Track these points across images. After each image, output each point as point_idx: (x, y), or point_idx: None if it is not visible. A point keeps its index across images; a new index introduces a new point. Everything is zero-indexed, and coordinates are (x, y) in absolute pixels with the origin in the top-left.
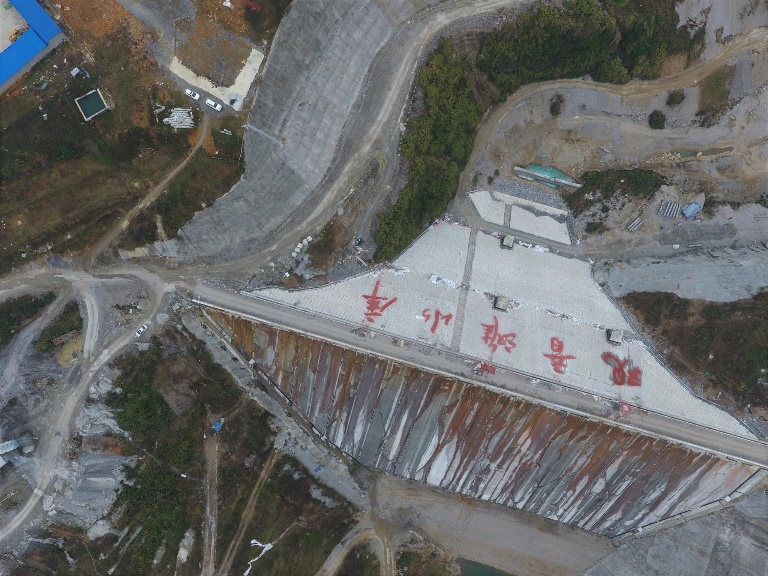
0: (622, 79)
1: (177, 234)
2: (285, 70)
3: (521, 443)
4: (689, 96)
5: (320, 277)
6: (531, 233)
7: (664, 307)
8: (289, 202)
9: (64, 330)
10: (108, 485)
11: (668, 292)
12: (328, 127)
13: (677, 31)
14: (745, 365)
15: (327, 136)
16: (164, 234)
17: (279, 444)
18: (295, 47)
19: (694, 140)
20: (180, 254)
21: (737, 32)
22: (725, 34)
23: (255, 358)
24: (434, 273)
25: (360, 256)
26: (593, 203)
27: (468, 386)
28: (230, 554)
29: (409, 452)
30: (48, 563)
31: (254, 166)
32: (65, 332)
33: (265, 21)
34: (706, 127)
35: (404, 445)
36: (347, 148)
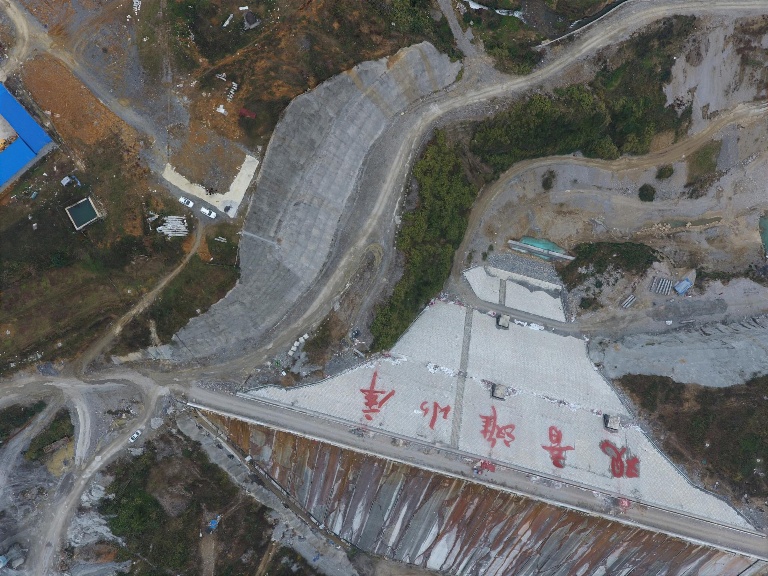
0: (612, 156)
1: (171, 340)
2: (280, 173)
3: (521, 534)
4: (678, 170)
5: (317, 373)
6: (526, 311)
7: (660, 391)
8: (285, 300)
9: (55, 438)
10: None
11: (663, 376)
12: (323, 223)
13: (665, 110)
14: (741, 455)
15: (322, 231)
16: (158, 339)
17: (277, 537)
18: (290, 150)
19: (683, 211)
20: (174, 357)
21: (722, 108)
22: (711, 110)
23: (252, 455)
24: (431, 361)
25: (357, 348)
26: (586, 277)
27: (468, 483)
28: None
29: (409, 540)
30: None
31: (249, 270)
32: (56, 440)
33: (259, 128)
34: (694, 198)
35: (404, 534)
36: (343, 242)
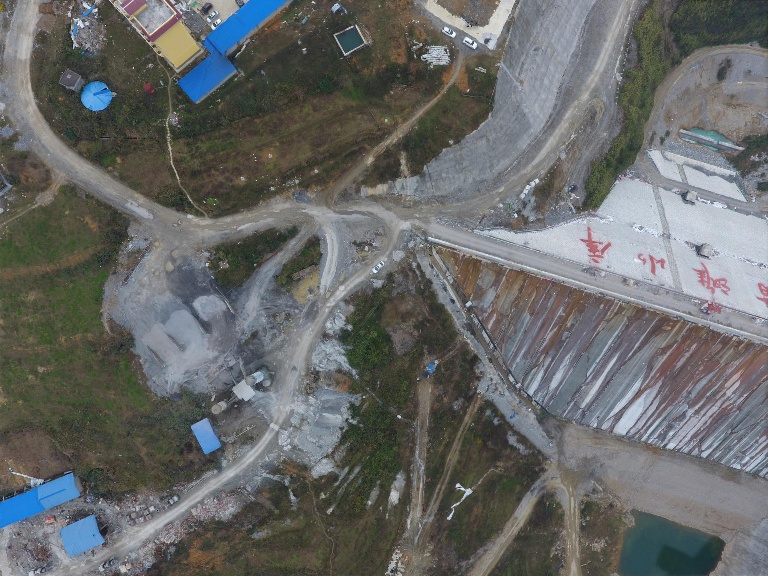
0: None
1: (422, 171)
2: (529, 13)
3: (728, 386)
4: None
5: (540, 220)
6: (709, 190)
7: None
8: (517, 145)
9: (304, 265)
10: (335, 422)
11: None
12: (552, 74)
13: None
14: None
15: (551, 83)
16: (407, 171)
17: (482, 389)
18: None
19: None
20: (416, 192)
21: None
22: None
23: (472, 300)
24: (636, 222)
25: (572, 202)
26: (760, 164)
27: (692, 326)
28: (436, 497)
29: (605, 399)
30: (274, 501)
31: (499, 105)
32: (304, 267)
33: None
34: None
35: (602, 391)
36: (567, 96)
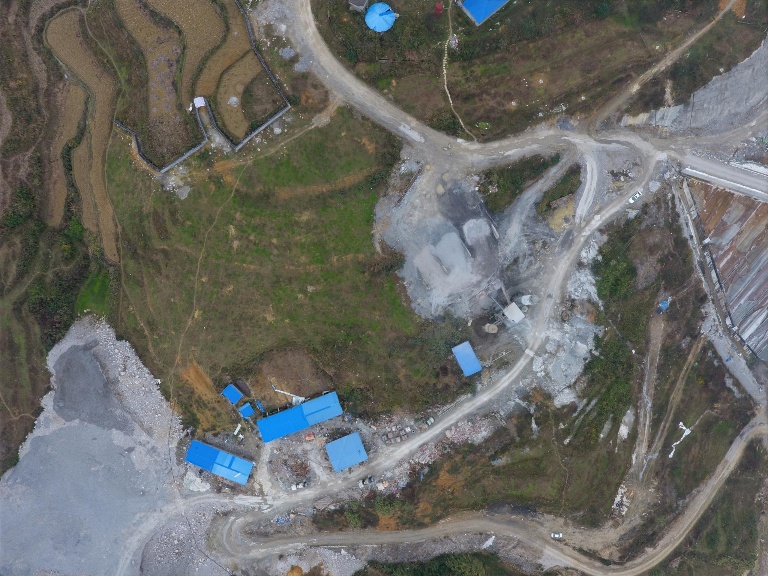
0: None
1: (689, 99)
2: None
3: None
4: None
5: None
6: None
7: None
8: None
9: (563, 193)
10: (581, 352)
11: None
12: None
13: None
14: None
15: None
16: (671, 100)
17: (706, 329)
18: None
19: None
20: (674, 123)
21: None
22: None
23: (711, 237)
24: None
25: None
26: None
27: None
28: (661, 434)
29: None
30: (518, 428)
31: None
32: (562, 195)
33: None
34: None
35: None
36: None
